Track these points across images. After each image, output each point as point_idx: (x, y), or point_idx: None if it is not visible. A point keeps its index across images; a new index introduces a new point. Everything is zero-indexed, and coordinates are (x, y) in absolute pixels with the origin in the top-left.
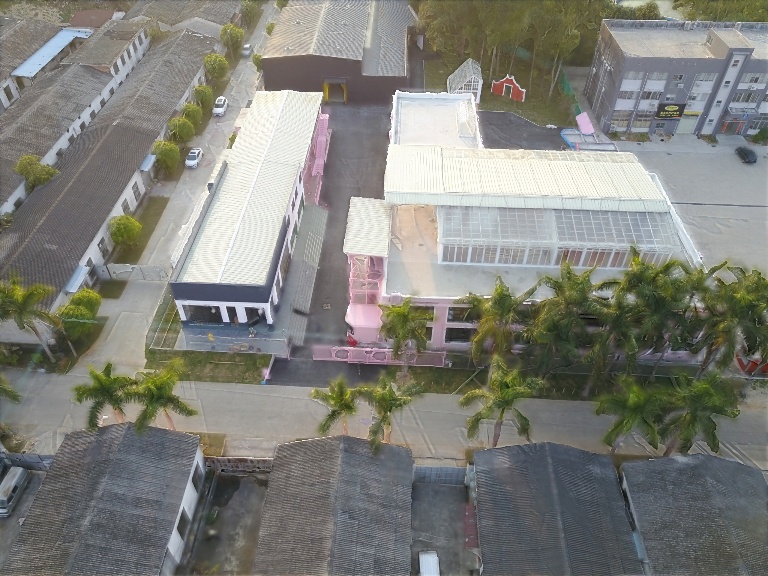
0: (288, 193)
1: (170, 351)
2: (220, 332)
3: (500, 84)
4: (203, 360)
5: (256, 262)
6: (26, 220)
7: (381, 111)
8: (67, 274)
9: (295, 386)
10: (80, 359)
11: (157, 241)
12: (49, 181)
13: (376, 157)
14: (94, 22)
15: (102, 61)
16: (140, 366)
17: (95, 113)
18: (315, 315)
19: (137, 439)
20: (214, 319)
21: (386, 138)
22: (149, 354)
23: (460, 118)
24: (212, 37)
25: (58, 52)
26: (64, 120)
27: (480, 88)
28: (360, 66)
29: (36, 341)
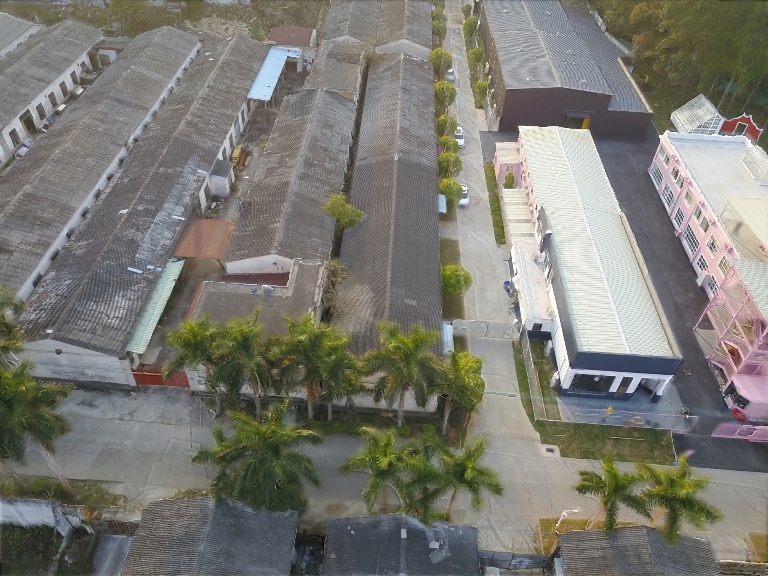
0: (629, 246)
1: (560, 423)
2: (601, 402)
3: (732, 122)
4: (600, 435)
5: (650, 329)
6: (365, 269)
7: (623, 148)
8: (439, 334)
9: (711, 468)
10: (468, 430)
11: (472, 291)
12: (359, 223)
13: (645, 200)
14: (294, 40)
15: (346, 87)
16: (536, 440)
17: (350, 143)
18: (680, 382)
19: (661, 547)
20: (596, 388)
21: (644, 178)
22: (538, 426)
23: (763, 166)
24: (427, 61)
25: (280, 73)
26: (339, 153)
27: (720, 126)
28: (609, 101)
29: (414, 408)
